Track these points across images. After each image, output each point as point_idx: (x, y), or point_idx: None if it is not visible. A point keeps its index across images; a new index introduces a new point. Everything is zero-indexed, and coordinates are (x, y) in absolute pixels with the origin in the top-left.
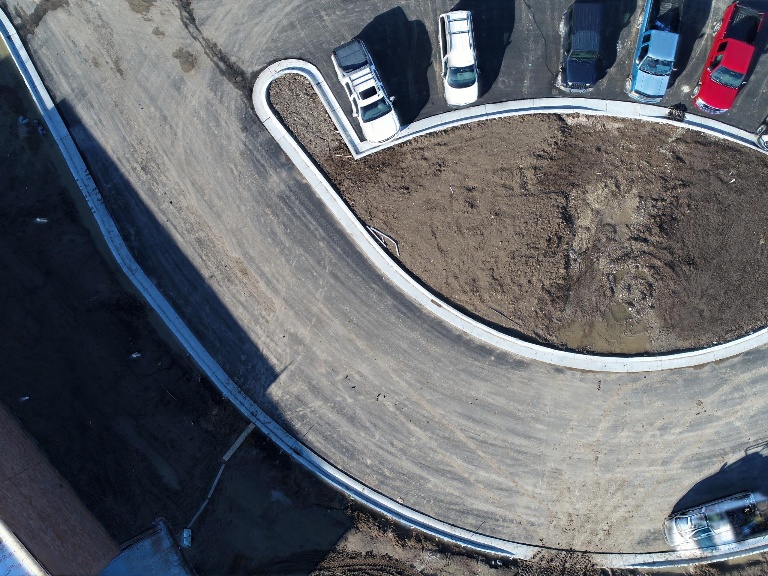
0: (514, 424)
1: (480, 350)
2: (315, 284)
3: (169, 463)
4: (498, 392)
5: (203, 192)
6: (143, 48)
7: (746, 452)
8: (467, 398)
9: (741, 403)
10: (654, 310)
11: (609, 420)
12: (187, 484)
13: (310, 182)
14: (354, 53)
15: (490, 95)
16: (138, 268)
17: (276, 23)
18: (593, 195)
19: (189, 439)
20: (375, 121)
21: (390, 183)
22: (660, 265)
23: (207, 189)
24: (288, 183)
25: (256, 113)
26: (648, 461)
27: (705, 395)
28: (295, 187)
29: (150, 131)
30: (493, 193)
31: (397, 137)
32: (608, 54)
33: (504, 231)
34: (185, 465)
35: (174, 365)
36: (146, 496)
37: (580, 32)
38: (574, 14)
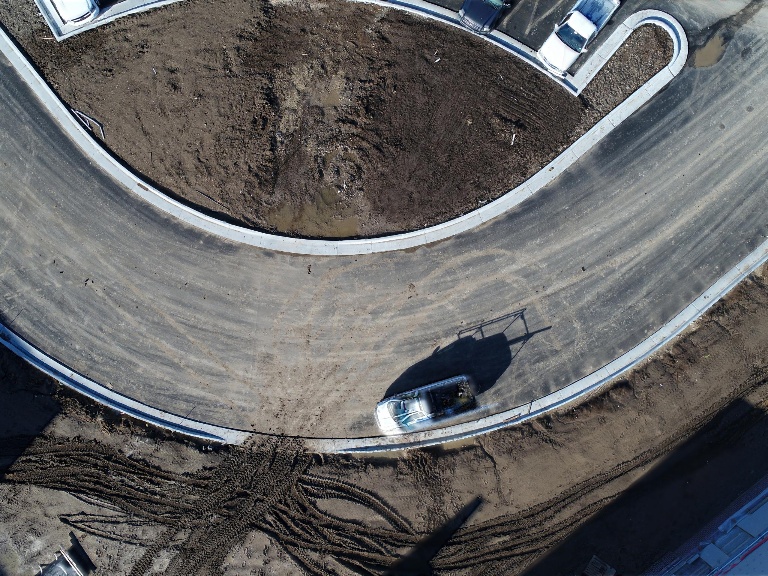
0: (224, 309)
1: (188, 234)
2: (21, 168)
3: None
4: (207, 276)
5: None
6: None
7: (459, 336)
8: (176, 283)
9: (453, 286)
10: (364, 193)
11: (320, 304)
12: None
13: (15, 66)
14: None
15: None
16: None
17: None
18: (299, 76)
19: None
20: None
21: (94, 65)
22: (369, 147)
23: None
24: None
25: None
26: (360, 345)
27: (417, 278)
28: None
29: None
30: (197, 74)
31: (100, 19)
32: None
33: (208, 113)
34: None
35: None
36: None
37: None
38: None
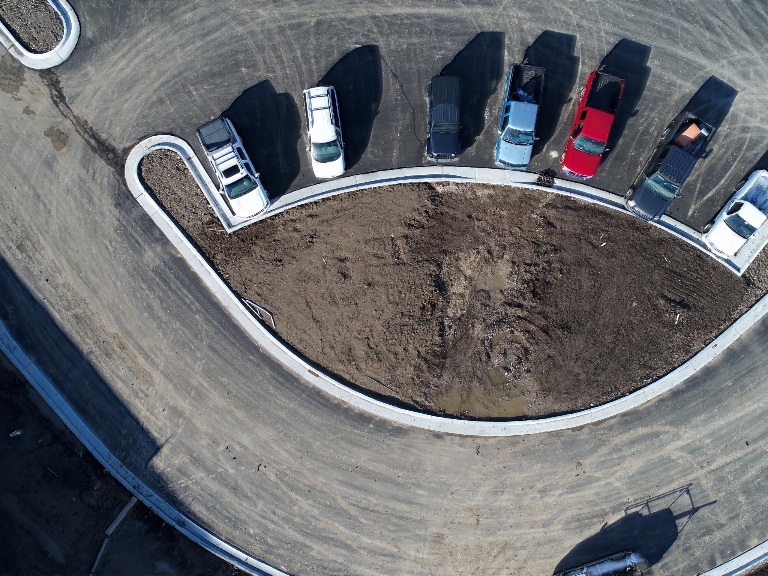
0: (395, 490)
1: (359, 418)
2: (193, 357)
3: (52, 539)
4: (378, 459)
5: (79, 269)
6: (14, 128)
7: (626, 512)
8: (347, 466)
9: (620, 463)
10: (530, 374)
11: (489, 484)
12: (71, 559)
13: (185, 256)
14: (218, 131)
15: (360, 166)
16: (16, 346)
17: (146, 99)
18: (466, 262)
19: (71, 515)
20: (242, 198)
21: (263, 256)
22: (535, 329)
23: (83, 266)
24: (163, 258)
25: (129, 189)
26: (529, 523)
27: (584, 456)
28: (170, 262)
29: (24, 210)
30: (366, 263)
31: (269, 210)
32: (476, 122)
33: (378, 300)
34: (68, 541)
35: (54, 442)
36: (30, 572)
37: (440, 105)
38: (434, 87)
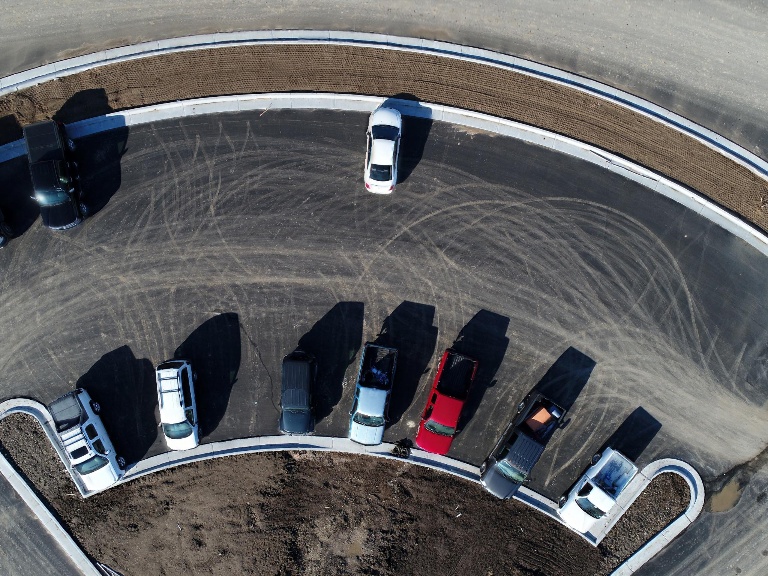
0: None
1: None
2: None
3: None
4: None
5: None
6: None
7: None
8: None
9: None
10: None
11: None
12: None
13: (41, 519)
14: (69, 408)
15: (217, 433)
16: None
17: (4, 362)
18: (322, 529)
19: None
20: (92, 473)
21: (119, 521)
22: None
23: None
24: (19, 520)
25: None
26: None
27: None
28: (26, 524)
29: None
30: (221, 530)
31: (125, 476)
32: (334, 391)
33: (233, 567)
34: None
35: None
36: None
37: (289, 390)
38: (283, 372)
